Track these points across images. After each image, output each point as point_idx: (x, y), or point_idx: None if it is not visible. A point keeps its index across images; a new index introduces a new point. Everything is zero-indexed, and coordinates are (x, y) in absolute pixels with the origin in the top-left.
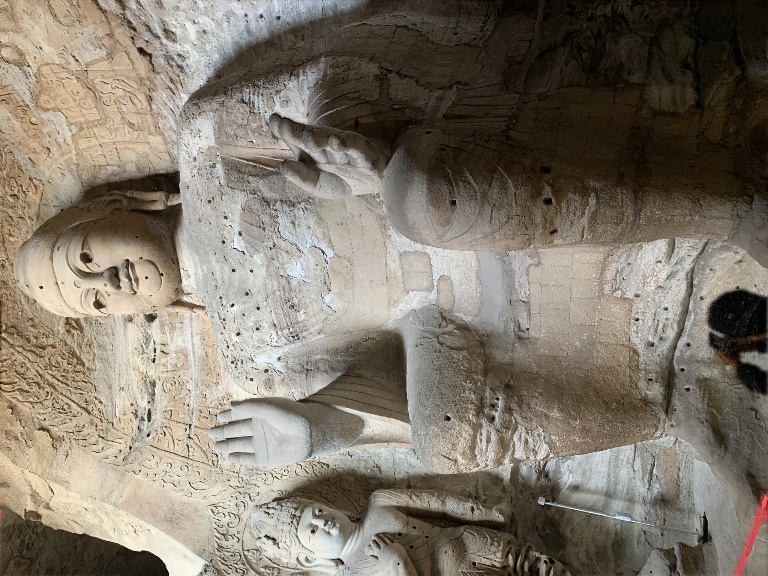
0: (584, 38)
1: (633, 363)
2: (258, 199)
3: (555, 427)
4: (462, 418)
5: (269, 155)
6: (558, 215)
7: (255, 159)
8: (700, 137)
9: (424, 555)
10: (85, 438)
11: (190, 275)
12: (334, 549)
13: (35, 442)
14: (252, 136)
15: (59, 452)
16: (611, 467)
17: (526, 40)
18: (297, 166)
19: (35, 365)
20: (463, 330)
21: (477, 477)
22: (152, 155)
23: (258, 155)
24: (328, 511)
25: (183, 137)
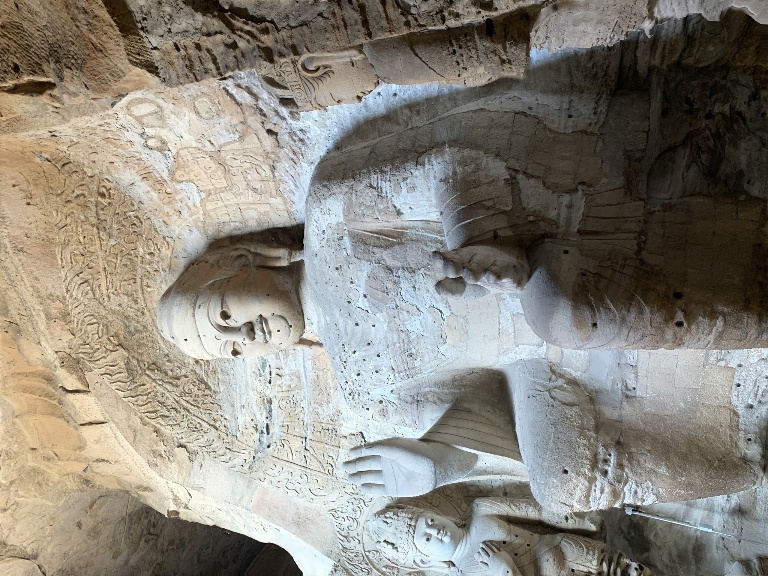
0: (703, 138)
1: (733, 424)
2: (382, 267)
3: (663, 482)
4: (579, 472)
5: (391, 227)
6: (688, 334)
7: (378, 231)
8: None
9: (528, 562)
10: (215, 450)
11: (313, 323)
12: (447, 554)
13: (175, 457)
14: (378, 214)
15: (195, 464)
16: None
17: (643, 131)
18: (450, 286)
19: (172, 394)
20: (572, 385)
21: None
22: (272, 213)
23: (381, 227)
24: (439, 520)
25: (313, 214)
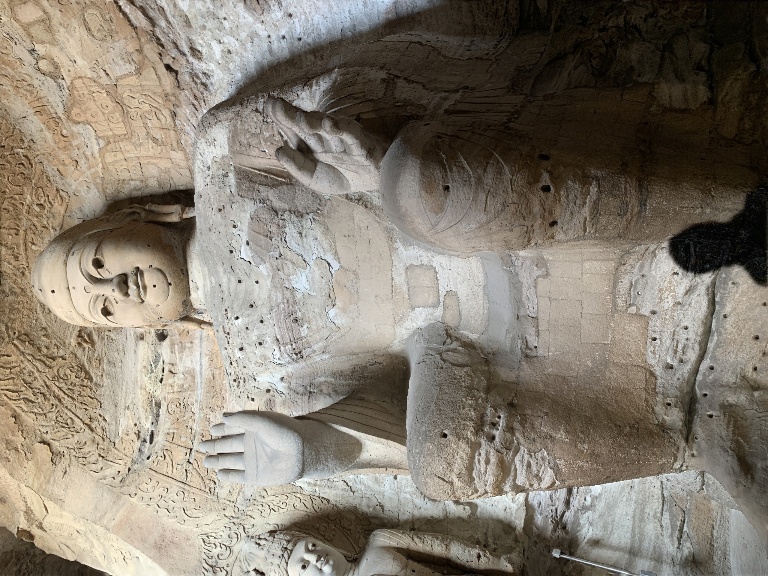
0: (595, 46)
1: (650, 386)
2: (267, 208)
3: (561, 450)
4: (459, 435)
5: (281, 166)
6: (557, 204)
7: (267, 170)
8: (713, 133)
9: None
10: (85, 456)
11: (199, 287)
12: None
13: (34, 455)
14: (264, 145)
15: (57, 468)
16: (636, 521)
17: (538, 52)
18: (293, 153)
19: (43, 375)
20: (468, 347)
21: (487, 524)
22: (173, 171)
23: (270, 166)
24: (322, 546)
25: (199, 146)
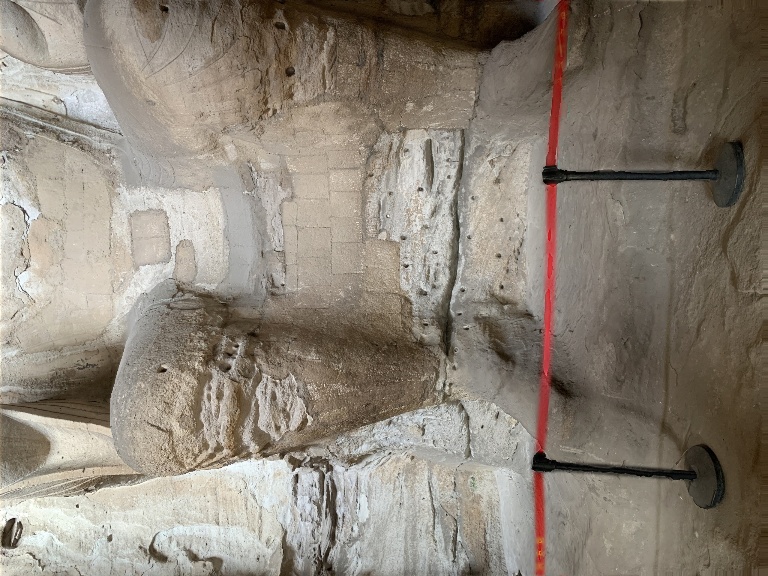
0: None
1: (405, 310)
2: None
3: (311, 372)
4: (183, 367)
5: None
6: (293, 44)
7: None
8: (439, 31)
9: None
10: None
11: None
12: None
13: None
14: None
15: None
16: (408, 541)
17: None
18: None
19: None
20: (203, 297)
21: None
22: None
23: None
24: None
25: None
